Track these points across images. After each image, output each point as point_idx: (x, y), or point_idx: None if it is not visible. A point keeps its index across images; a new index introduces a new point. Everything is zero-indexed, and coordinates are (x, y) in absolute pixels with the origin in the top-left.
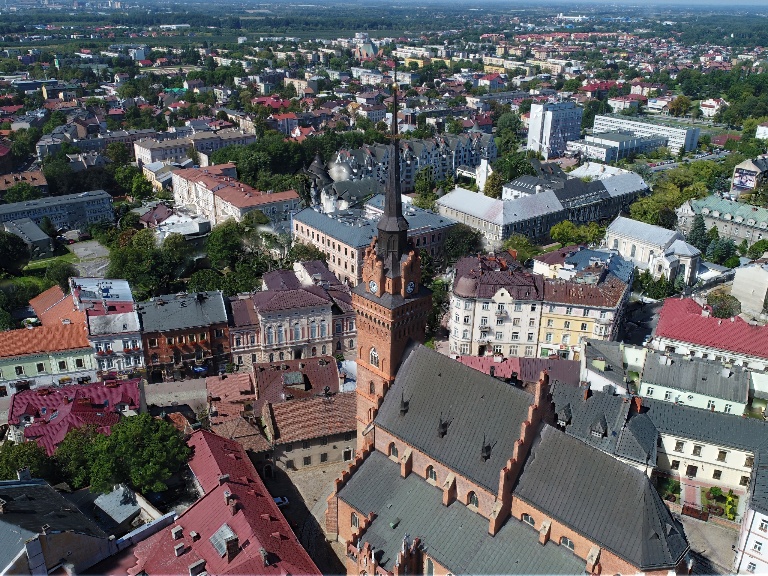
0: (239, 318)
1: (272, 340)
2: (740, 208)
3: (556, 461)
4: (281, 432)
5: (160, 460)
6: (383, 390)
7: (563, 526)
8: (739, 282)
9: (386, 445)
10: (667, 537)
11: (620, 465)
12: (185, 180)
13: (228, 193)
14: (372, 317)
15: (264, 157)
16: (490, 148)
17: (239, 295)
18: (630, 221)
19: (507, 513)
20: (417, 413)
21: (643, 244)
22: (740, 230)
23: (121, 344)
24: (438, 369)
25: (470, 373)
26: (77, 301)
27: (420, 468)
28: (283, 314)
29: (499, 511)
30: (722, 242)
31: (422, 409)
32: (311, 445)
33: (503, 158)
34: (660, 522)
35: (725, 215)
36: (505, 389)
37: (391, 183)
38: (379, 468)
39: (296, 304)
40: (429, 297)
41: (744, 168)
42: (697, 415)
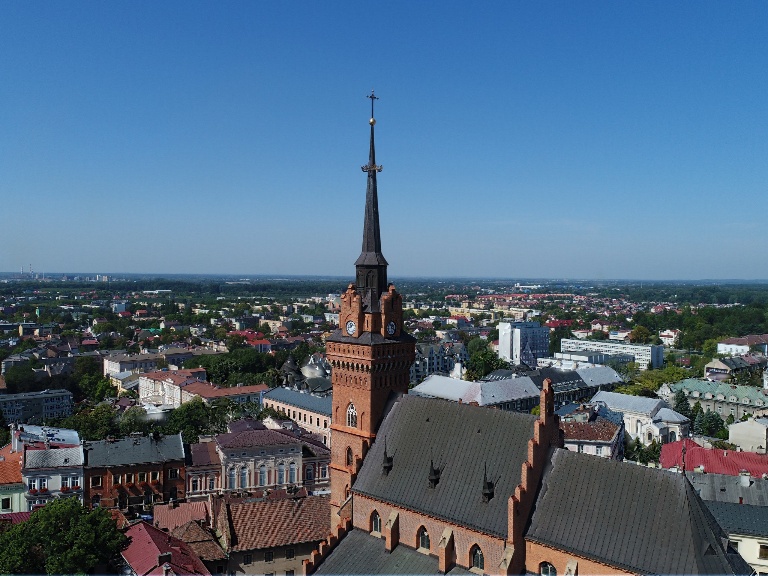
0: (198, 458)
1: (234, 484)
2: (719, 387)
3: (574, 487)
4: (239, 538)
5: (86, 542)
6: (362, 450)
7: (593, 563)
8: (735, 439)
9: (366, 517)
10: (725, 554)
11: (651, 472)
12: (152, 381)
13: (196, 387)
14: (349, 363)
15: (236, 363)
16: (463, 354)
17: (200, 437)
18: (611, 394)
19: (520, 568)
20: (403, 468)
21: (628, 414)
22: (723, 408)
23: (59, 481)
24: (425, 414)
25: (462, 409)
26: (16, 440)
27: (409, 535)
28: (248, 453)
29: (510, 558)
30: (708, 414)
31: (409, 462)
32: (275, 557)
33: (476, 357)
34: (713, 533)
35: (705, 394)
36: (504, 416)
37: (369, 216)
38: (358, 546)
39: (263, 442)
40: (412, 345)
41: (714, 367)
42: (725, 507)
